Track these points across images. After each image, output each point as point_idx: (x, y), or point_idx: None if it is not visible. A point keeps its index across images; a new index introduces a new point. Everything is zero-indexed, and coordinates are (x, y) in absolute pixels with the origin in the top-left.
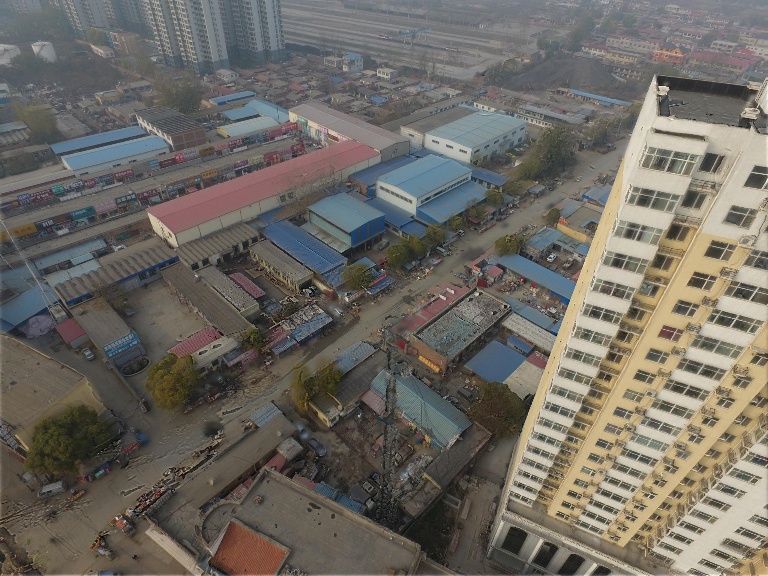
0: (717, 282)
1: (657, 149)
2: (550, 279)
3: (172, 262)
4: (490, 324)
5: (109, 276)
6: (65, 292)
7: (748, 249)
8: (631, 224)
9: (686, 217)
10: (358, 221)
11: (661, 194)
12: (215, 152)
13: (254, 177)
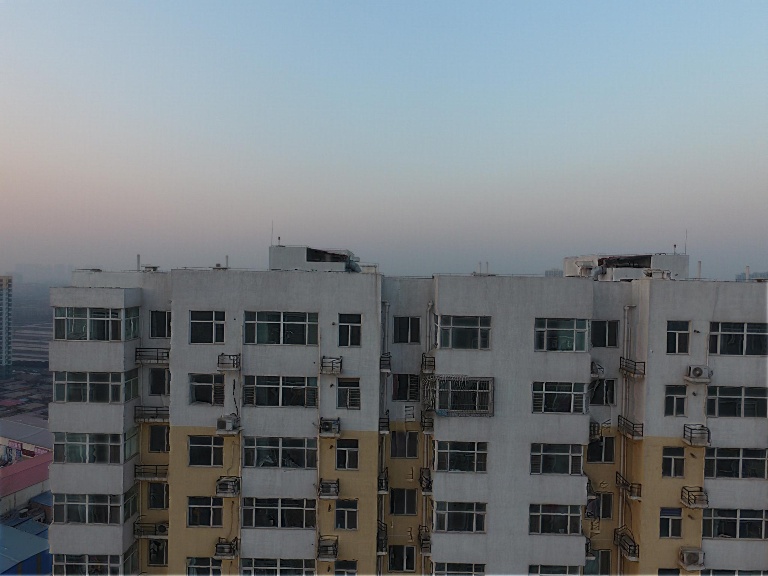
0: (225, 506)
1: (66, 309)
2: None
3: None
4: None
5: None
6: None
7: (235, 437)
8: (71, 435)
9: (155, 409)
10: (1, 565)
11: (95, 376)
12: None
13: None
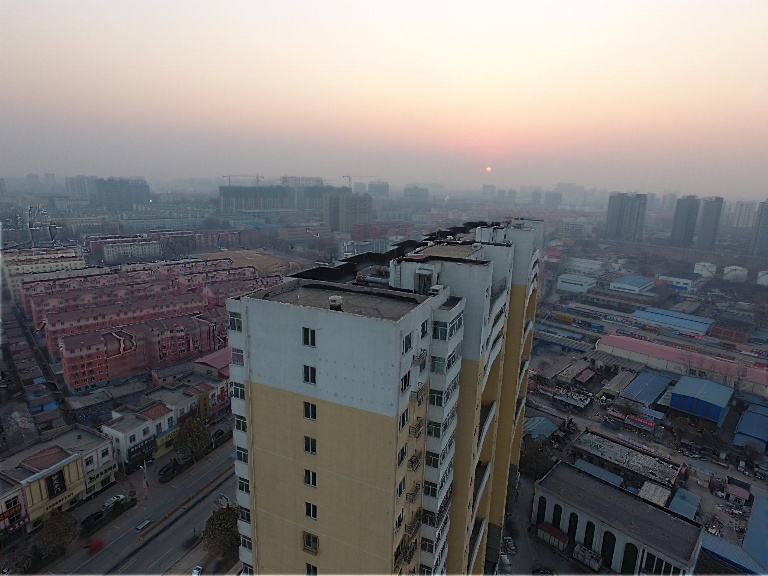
0: None
1: None
2: (767, 531)
3: (580, 352)
4: (635, 470)
5: (553, 340)
6: (534, 334)
7: None
8: None
9: None
10: (691, 394)
11: None
12: (731, 348)
13: (698, 355)
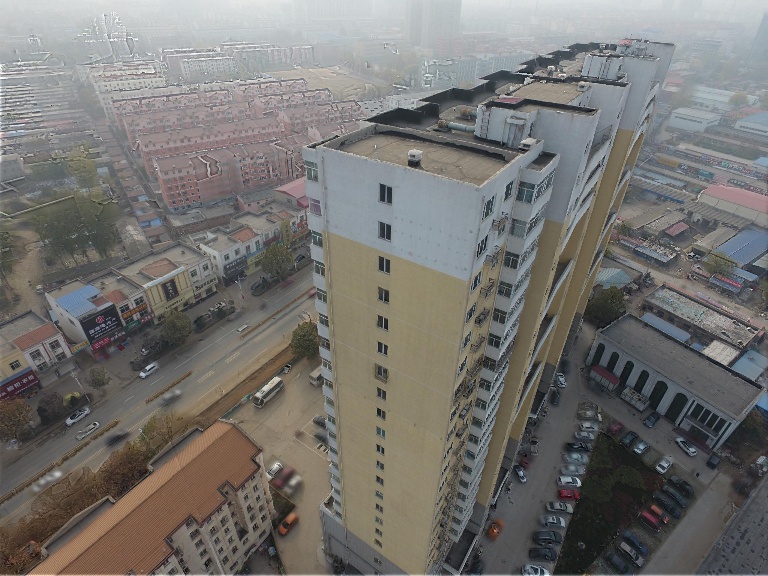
0: None
1: None
2: None
3: (678, 202)
4: (707, 329)
5: (649, 187)
6: None
7: None
8: None
9: None
10: None
11: None
12: None
13: None
